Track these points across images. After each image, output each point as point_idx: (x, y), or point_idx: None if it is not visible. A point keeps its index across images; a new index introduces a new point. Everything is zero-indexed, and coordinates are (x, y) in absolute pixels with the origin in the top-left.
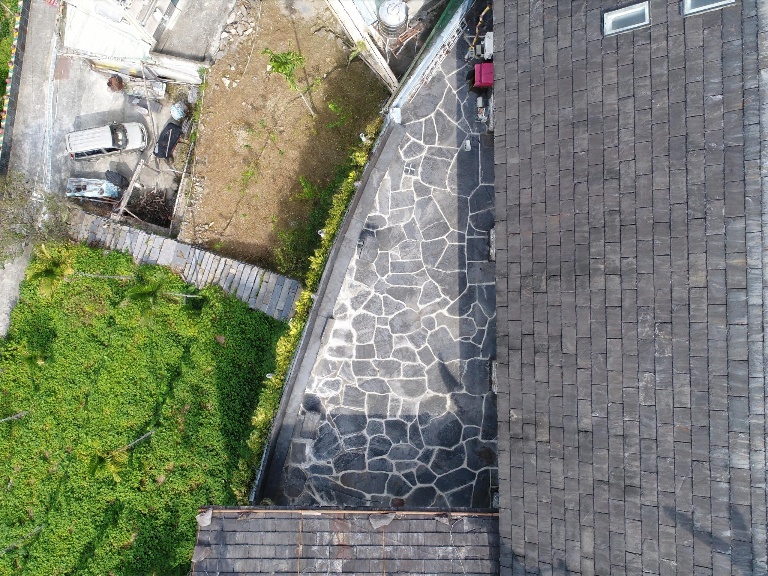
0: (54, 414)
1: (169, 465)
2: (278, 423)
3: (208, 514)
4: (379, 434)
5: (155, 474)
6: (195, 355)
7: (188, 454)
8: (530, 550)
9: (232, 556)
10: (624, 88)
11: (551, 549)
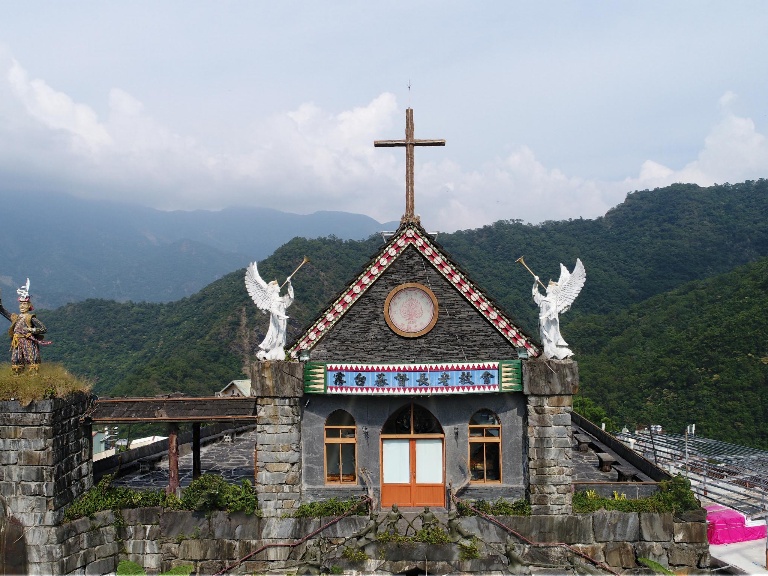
0: None
1: None
2: (124, 456)
3: None
4: None
5: None
6: None
7: None
8: None
9: None
10: None
11: None
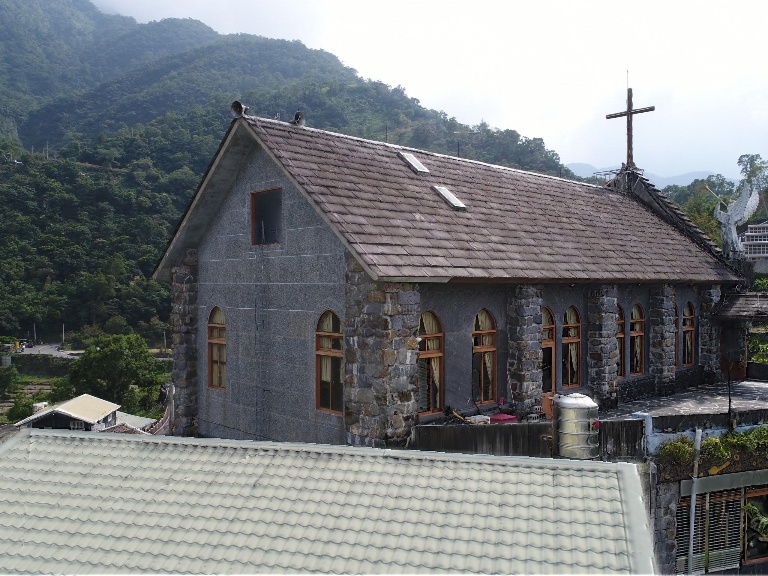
0: None
1: None
2: None
3: None
4: None
5: None
6: None
7: None
8: None
9: None
10: (486, 205)
11: None
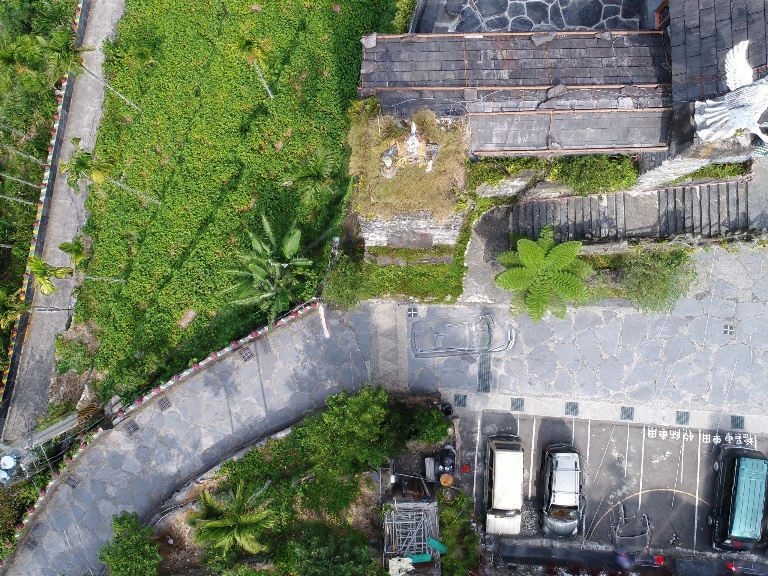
0: (165, 109)
1: (287, 132)
2: None
3: (373, 37)
4: (520, 15)
5: (273, 140)
6: (312, 21)
7: (306, 118)
8: (706, 15)
9: (399, 70)
10: None
11: (730, 3)
